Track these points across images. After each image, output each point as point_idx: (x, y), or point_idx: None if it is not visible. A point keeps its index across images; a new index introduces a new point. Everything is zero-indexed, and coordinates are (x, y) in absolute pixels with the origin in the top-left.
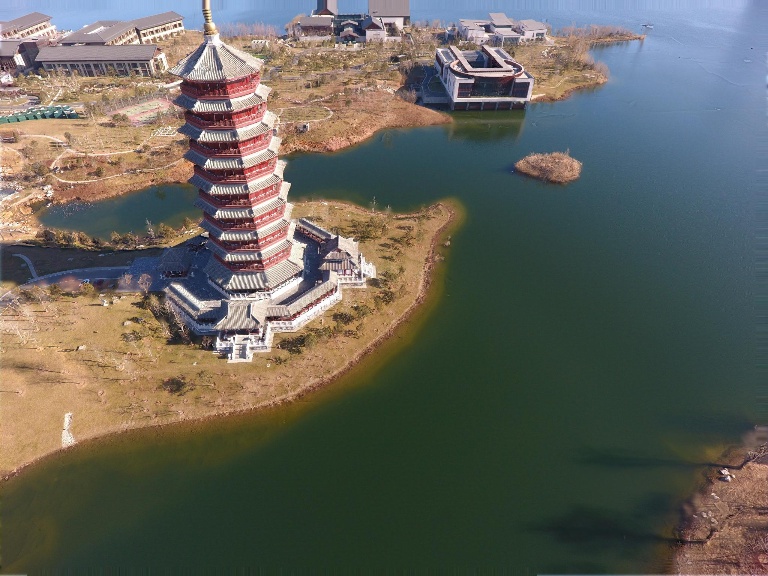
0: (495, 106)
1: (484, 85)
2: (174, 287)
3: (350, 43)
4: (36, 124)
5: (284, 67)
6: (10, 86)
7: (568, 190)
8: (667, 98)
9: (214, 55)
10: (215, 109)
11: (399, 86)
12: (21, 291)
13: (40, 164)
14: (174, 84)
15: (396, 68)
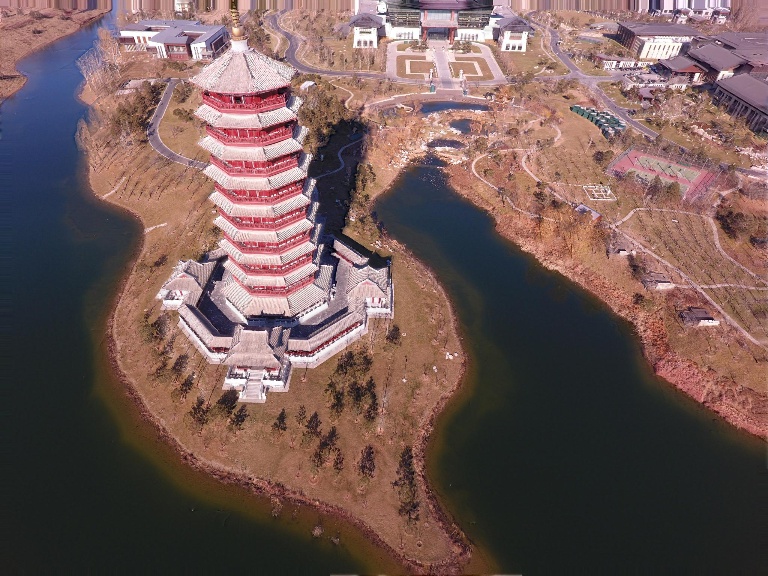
0: None
1: None
2: None
3: None
4: (580, 124)
5: None
6: None
7: None
8: None
9: None
10: None
11: None
12: None
13: (496, 144)
14: None
15: None
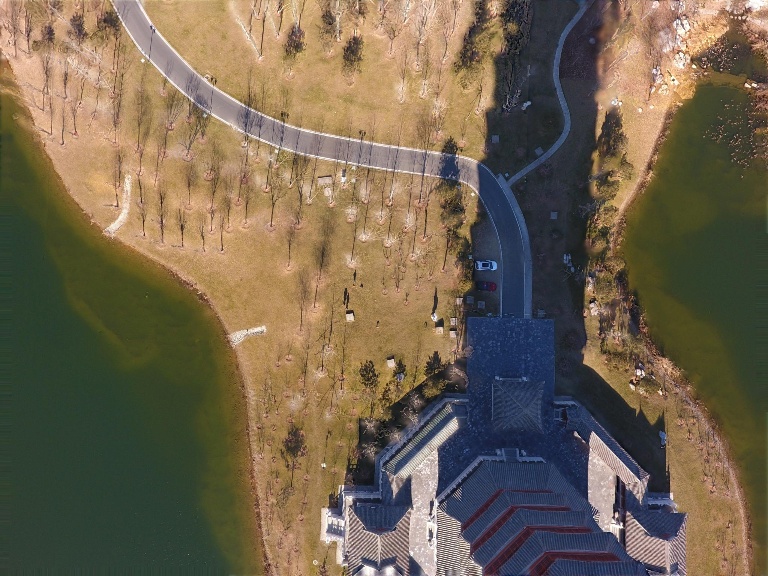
0: None
1: None
2: (447, 425)
3: None
4: None
5: None
6: None
7: None
8: None
9: None
10: None
11: None
12: (449, 199)
13: None
14: None
15: None
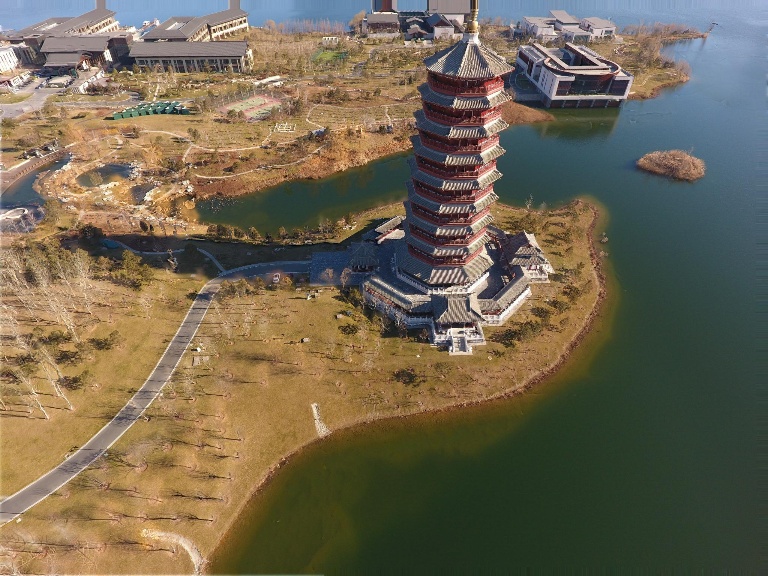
0: (591, 104)
1: (583, 83)
2: (376, 281)
3: (419, 40)
4: (150, 120)
5: (367, 64)
6: (108, 82)
7: (697, 188)
8: (756, 97)
9: (476, 53)
10: (473, 106)
11: None
12: (229, 284)
13: (173, 159)
14: (267, 80)
15: None
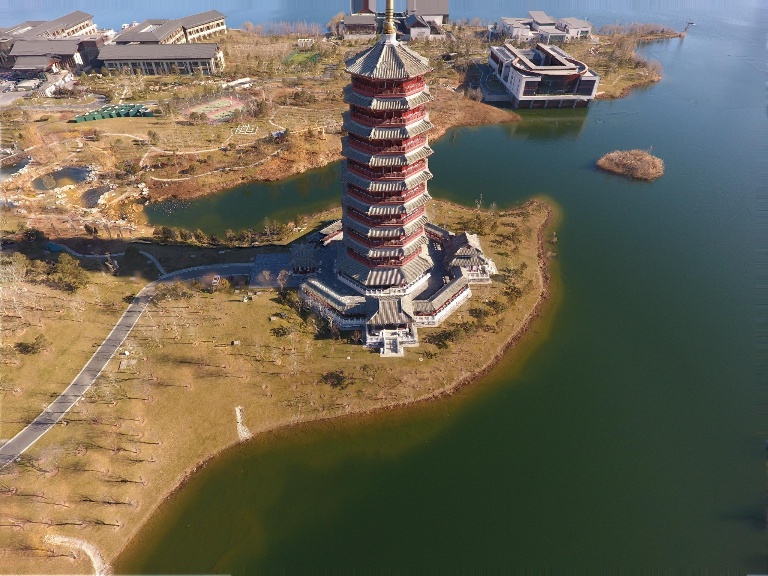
0: (559, 104)
1: (550, 83)
2: (313, 283)
3: None
4: (113, 122)
5: (339, 65)
6: (75, 85)
7: (655, 187)
8: (726, 96)
9: (393, 54)
10: (391, 107)
11: (458, 84)
12: (164, 287)
13: (130, 162)
14: (236, 82)
15: (450, 66)
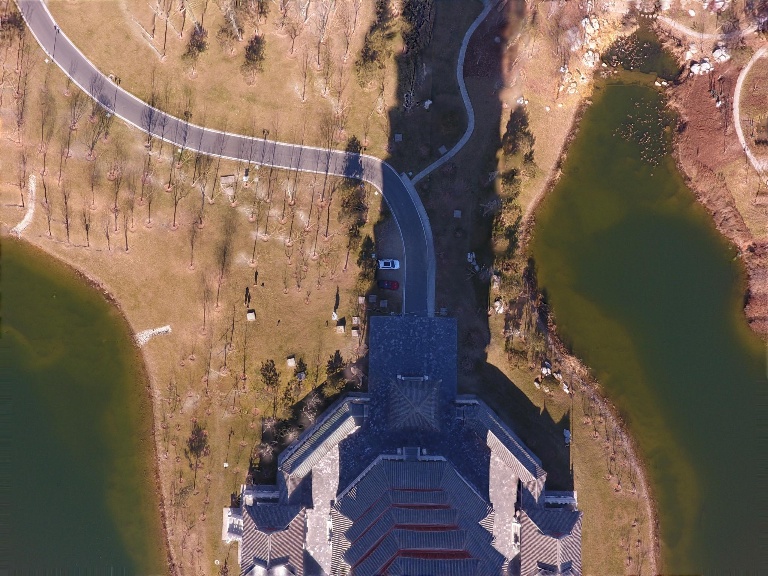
0: None
1: None
2: (343, 424)
3: None
4: None
5: None
6: None
7: None
8: None
9: None
10: None
11: None
12: (346, 198)
13: None
14: None
15: None
